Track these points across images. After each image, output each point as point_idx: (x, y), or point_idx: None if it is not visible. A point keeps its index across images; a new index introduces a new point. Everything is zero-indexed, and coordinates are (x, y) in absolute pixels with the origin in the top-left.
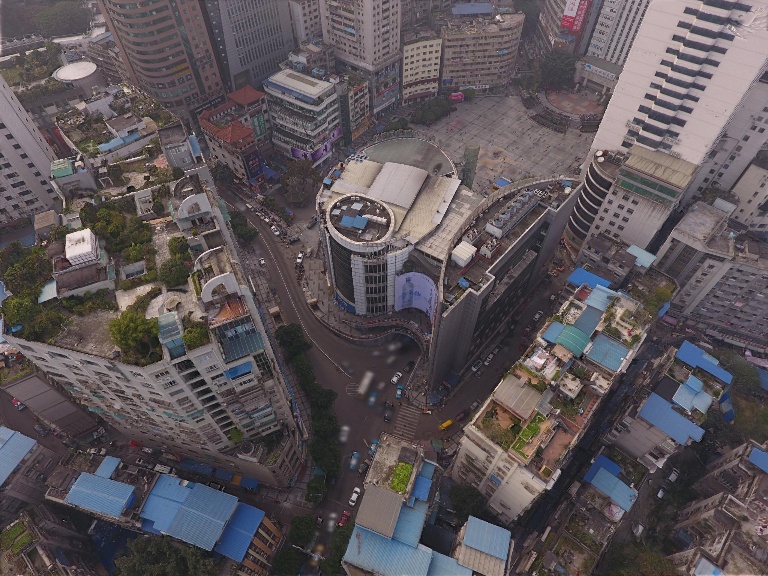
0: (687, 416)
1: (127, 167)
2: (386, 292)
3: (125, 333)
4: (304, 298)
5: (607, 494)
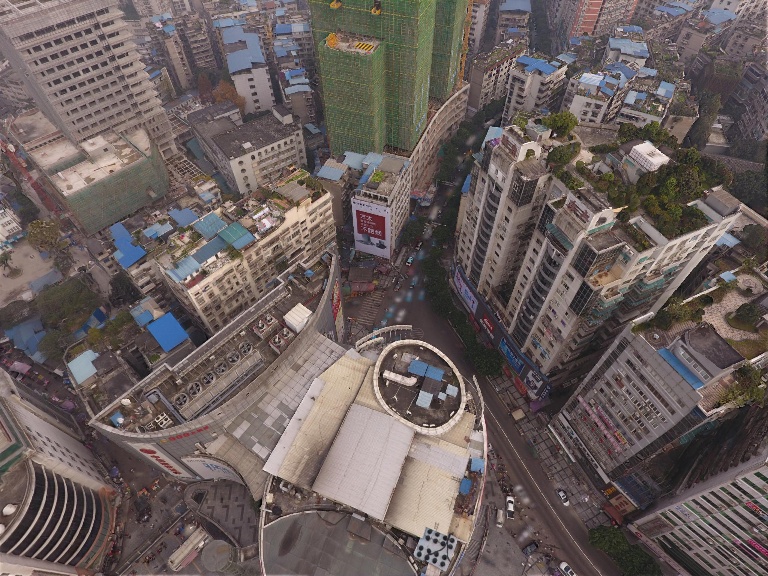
0: (171, 222)
1: (755, 347)
2: None
3: None
4: None
5: None
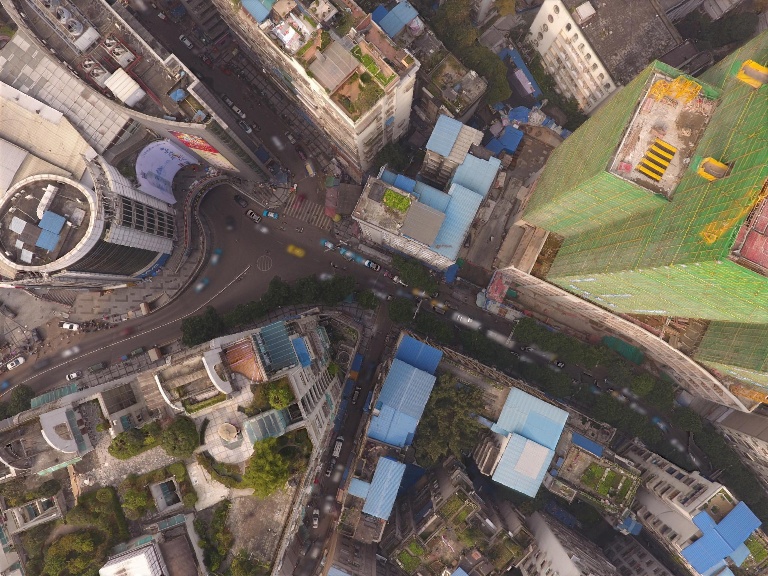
0: None
1: None
2: (153, 209)
3: (275, 475)
4: (138, 319)
5: (403, 26)
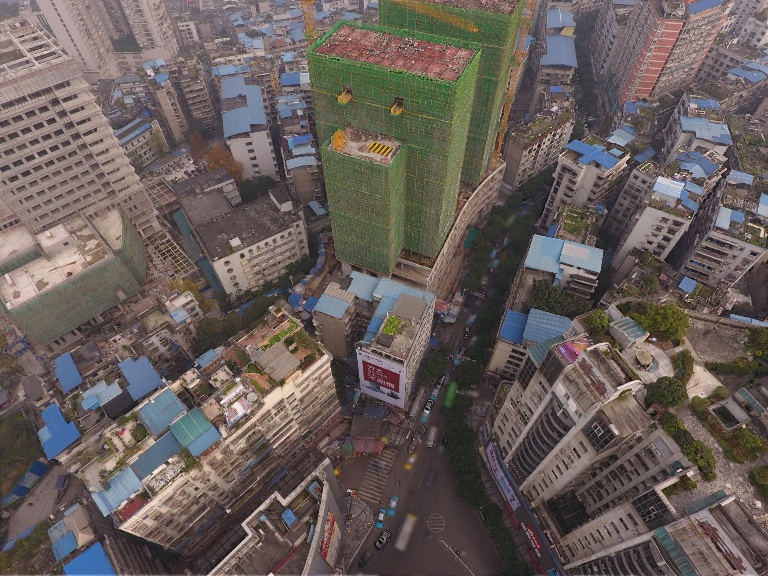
0: (121, 380)
1: None
2: None
3: None
4: None
5: None
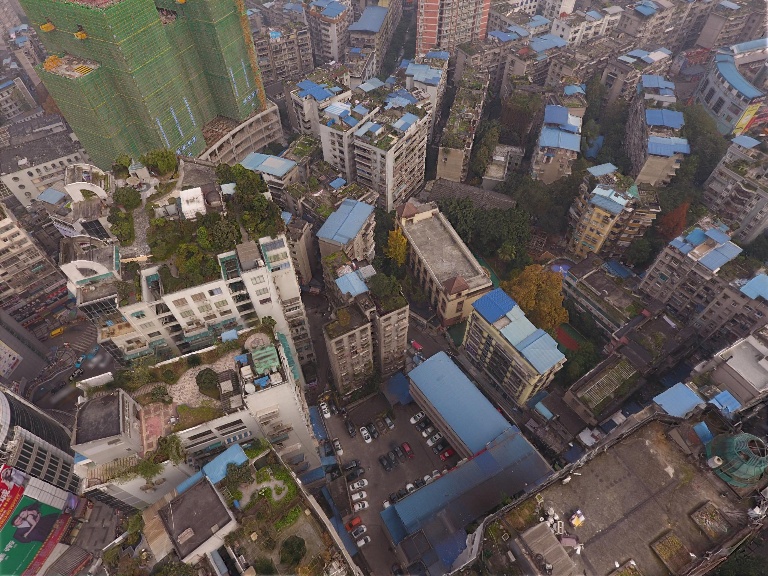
0: None
1: (203, 416)
2: None
3: None
4: None
5: None
